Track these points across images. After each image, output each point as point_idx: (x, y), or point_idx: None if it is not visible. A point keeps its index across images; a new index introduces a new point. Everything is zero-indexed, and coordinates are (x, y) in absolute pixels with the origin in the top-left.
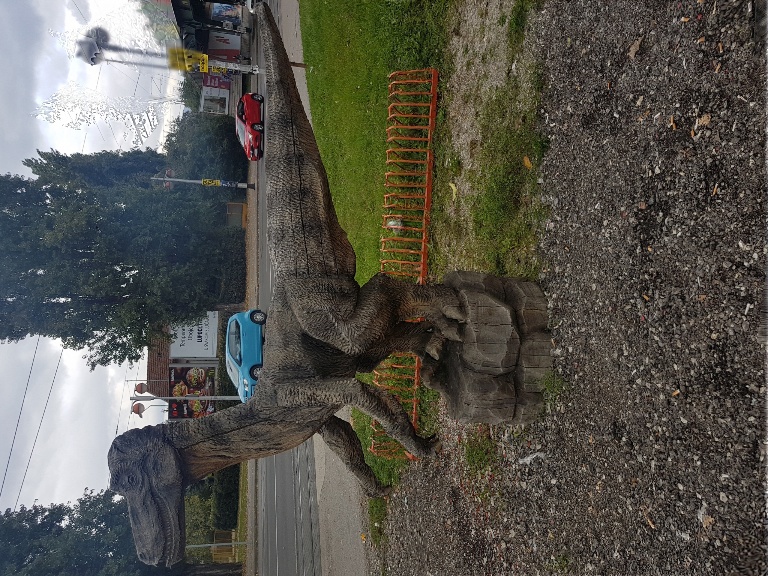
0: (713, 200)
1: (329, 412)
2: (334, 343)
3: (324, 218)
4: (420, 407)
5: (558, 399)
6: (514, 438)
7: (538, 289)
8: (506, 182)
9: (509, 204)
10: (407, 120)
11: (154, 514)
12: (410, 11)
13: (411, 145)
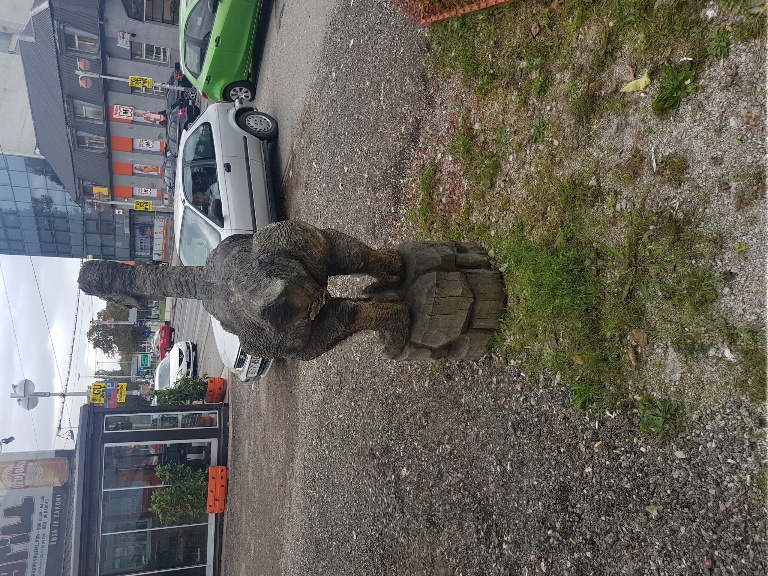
0: (480, 574)
1: None
2: None
3: None
4: None
5: None
6: None
7: (484, 352)
8: None
9: None
10: None
11: None
12: None
13: None
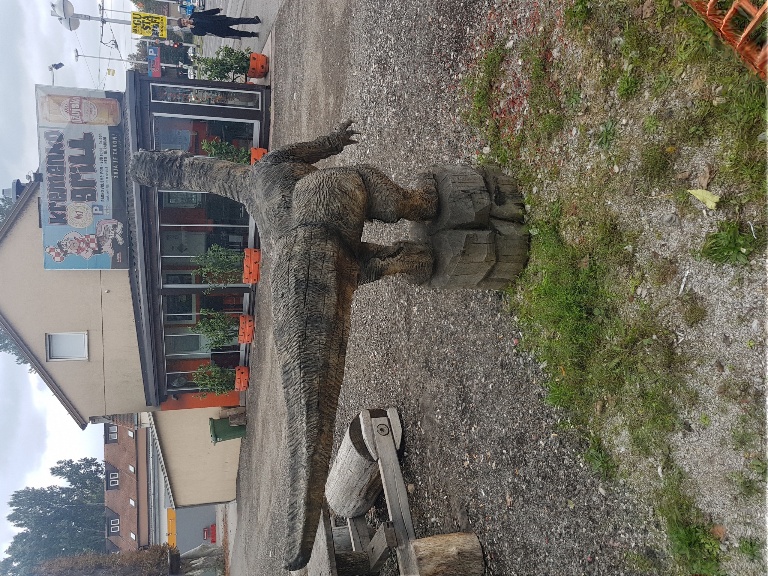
0: None
1: None
2: None
3: None
4: None
5: None
6: None
7: None
8: None
9: None
10: None
11: None
12: None
13: None
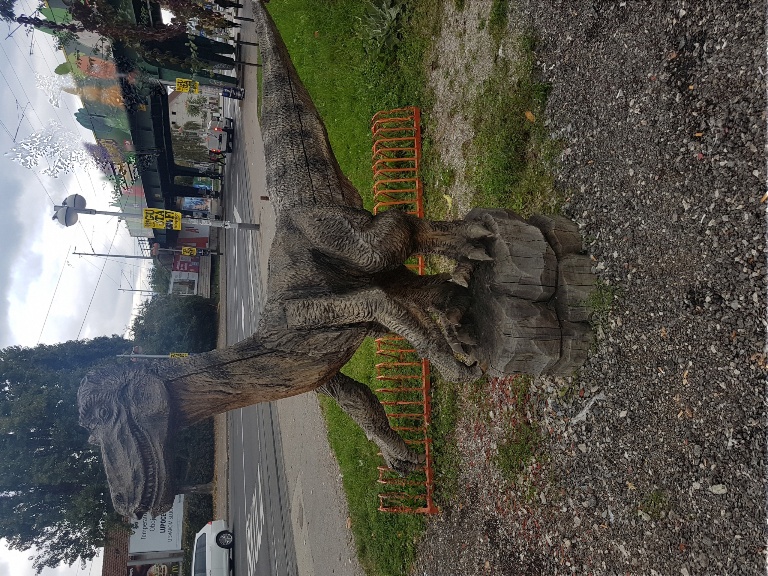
0: None
1: (348, 341)
2: (351, 254)
3: (328, 156)
4: (433, 446)
5: (611, 315)
6: (561, 397)
7: (564, 218)
8: (509, 144)
9: (516, 160)
10: (393, 153)
11: (131, 449)
12: (386, 70)
13: (399, 175)
